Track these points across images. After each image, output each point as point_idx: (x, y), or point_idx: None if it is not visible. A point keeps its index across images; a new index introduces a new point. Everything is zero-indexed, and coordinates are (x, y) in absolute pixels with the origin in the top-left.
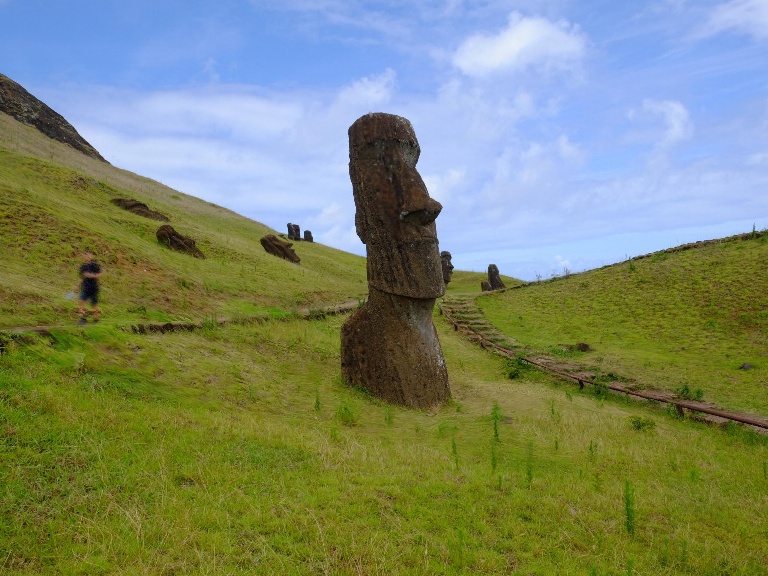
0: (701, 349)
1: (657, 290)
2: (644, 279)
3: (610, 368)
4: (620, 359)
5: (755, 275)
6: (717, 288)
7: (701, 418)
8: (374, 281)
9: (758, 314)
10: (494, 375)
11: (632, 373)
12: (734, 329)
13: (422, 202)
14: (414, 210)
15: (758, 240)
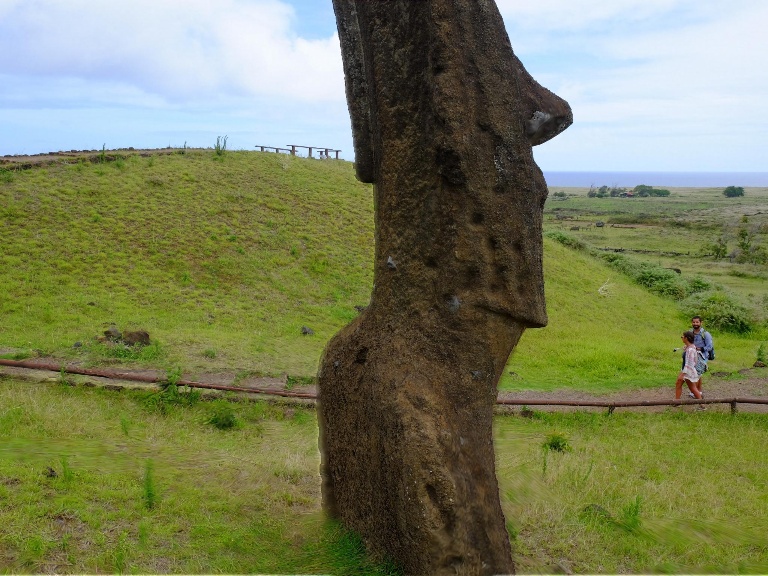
0: (226, 314)
1: (52, 229)
2: (15, 211)
3: (250, 366)
4: (224, 348)
5: (163, 212)
6: (135, 228)
7: (502, 411)
8: (508, 296)
9: (221, 262)
10: (193, 430)
11: (280, 367)
12: (215, 283)
13: (552, 97)
14: (557, 114)
15: (111, 165)
